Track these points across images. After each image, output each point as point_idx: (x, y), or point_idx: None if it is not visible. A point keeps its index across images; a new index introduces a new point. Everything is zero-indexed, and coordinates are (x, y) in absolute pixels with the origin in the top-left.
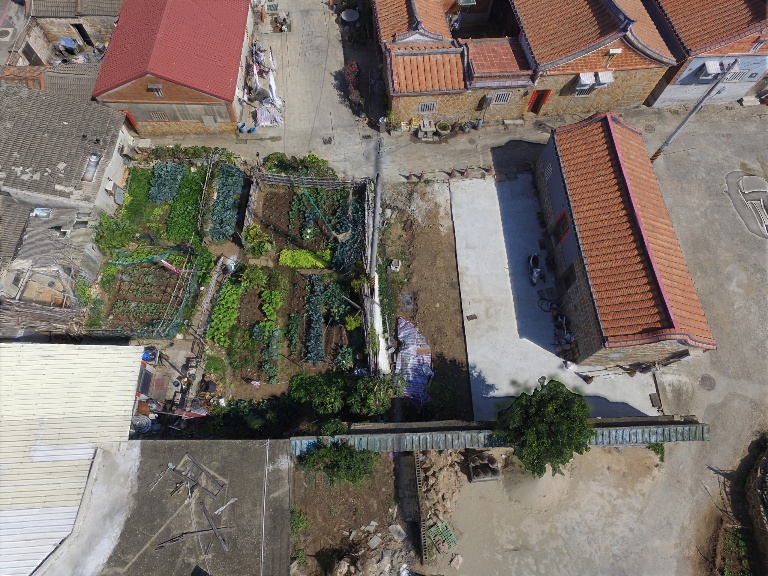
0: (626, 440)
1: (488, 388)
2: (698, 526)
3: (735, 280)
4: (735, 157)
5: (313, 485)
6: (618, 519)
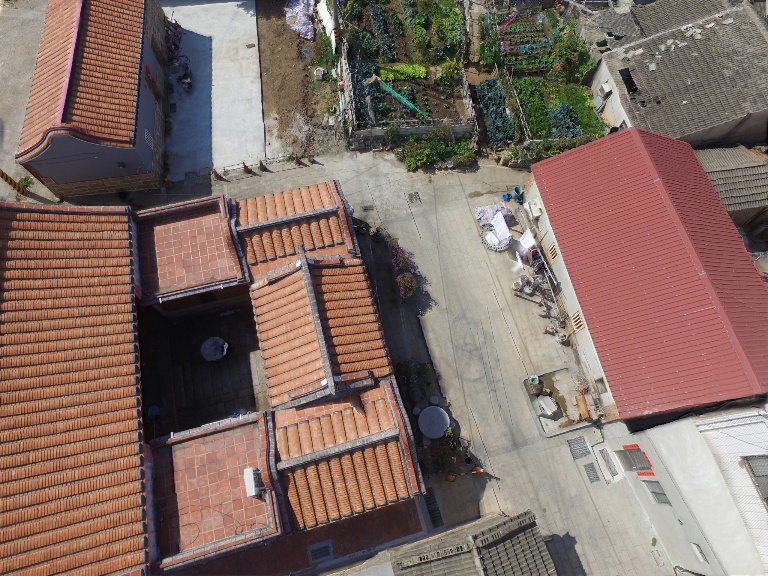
0: None
1: (242, 6)
2: None
3: None
4: None
5: None
6: None
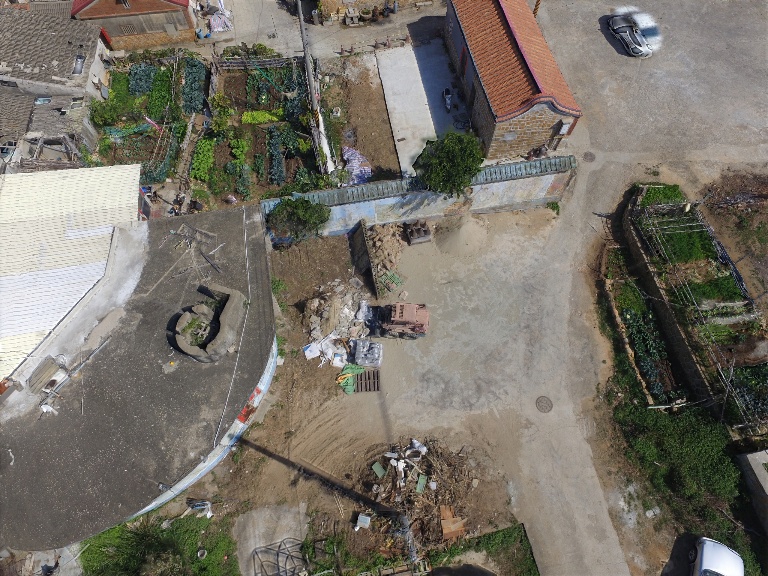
0: (514, 175)
1: None
2: (588, 252)
3: (608, 87)
4: (606, 5)
5: (287, 262)
6: (526, 254)
